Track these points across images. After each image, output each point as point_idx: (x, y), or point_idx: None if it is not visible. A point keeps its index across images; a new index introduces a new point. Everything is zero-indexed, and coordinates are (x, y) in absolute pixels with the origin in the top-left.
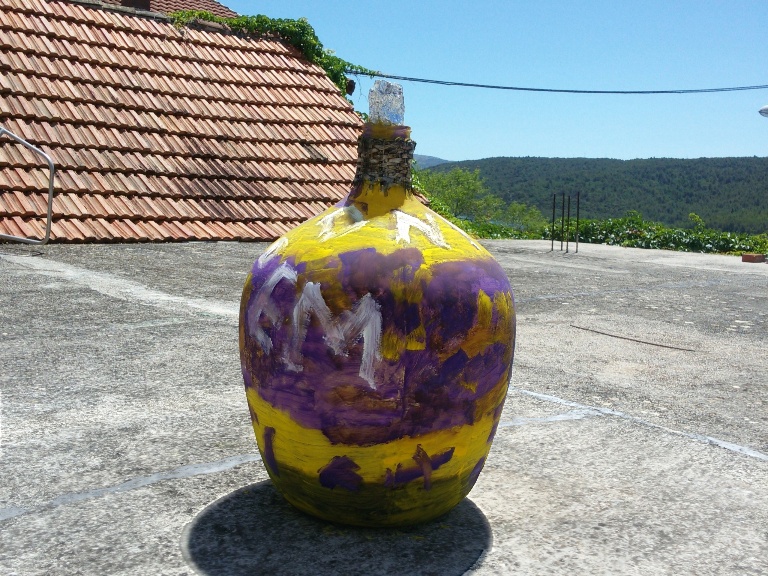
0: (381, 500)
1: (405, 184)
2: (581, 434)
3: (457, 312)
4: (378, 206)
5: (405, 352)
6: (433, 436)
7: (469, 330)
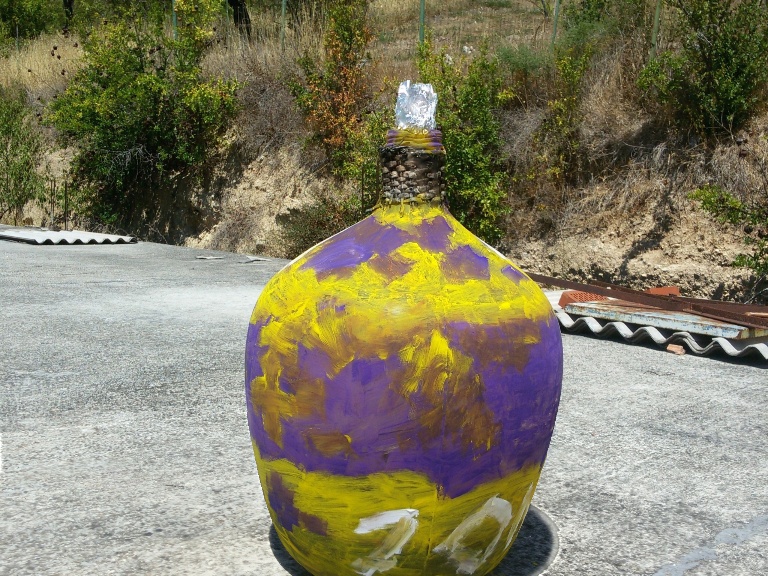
0: None
1: None
2: None
3: None
4: None
5: None
6: None
7: None
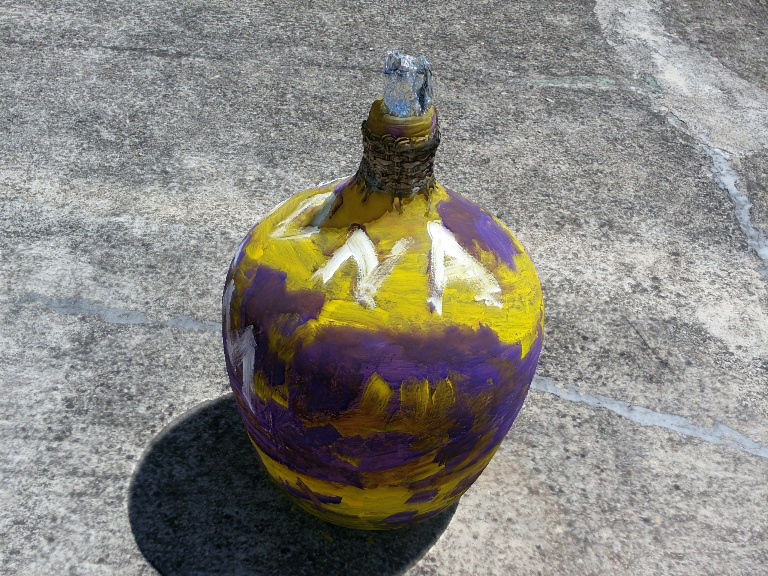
0: (285, 493)
1: (395, 191)
2: (759, 501)
3: (328, 388)
4: (346, 212)
5: (271, 400)
6: (311, 479)
7: (342, 411)
